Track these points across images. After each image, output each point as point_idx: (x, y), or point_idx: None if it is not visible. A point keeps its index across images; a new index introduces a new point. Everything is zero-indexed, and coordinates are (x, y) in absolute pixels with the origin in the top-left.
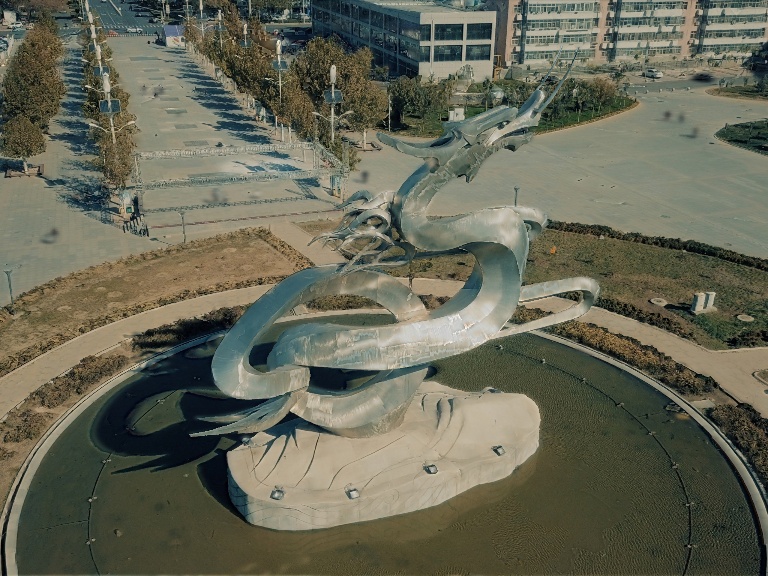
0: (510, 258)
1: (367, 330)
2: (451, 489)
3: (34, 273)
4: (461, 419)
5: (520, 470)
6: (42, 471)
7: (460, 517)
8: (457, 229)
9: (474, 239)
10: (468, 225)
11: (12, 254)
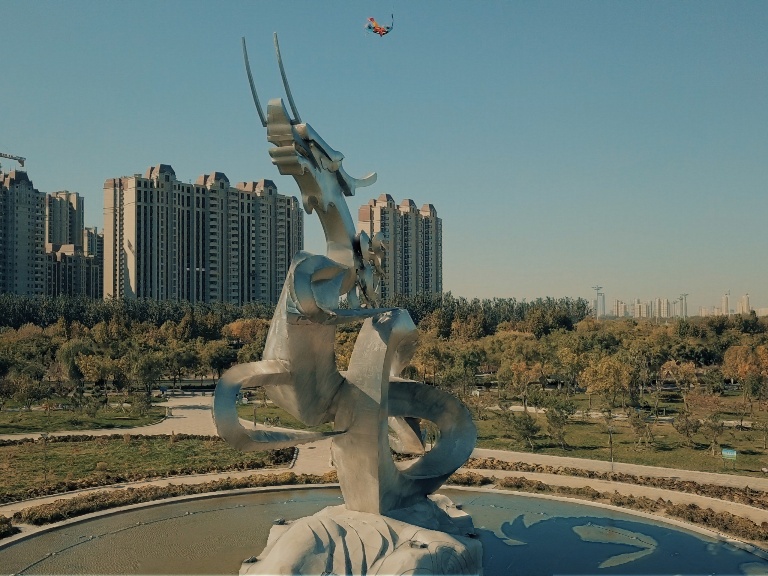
0: None
1: None
2: None
3: None
4: None
5: None
6: (555, 502)
7: None
8: None
9: None
10: None
11: None
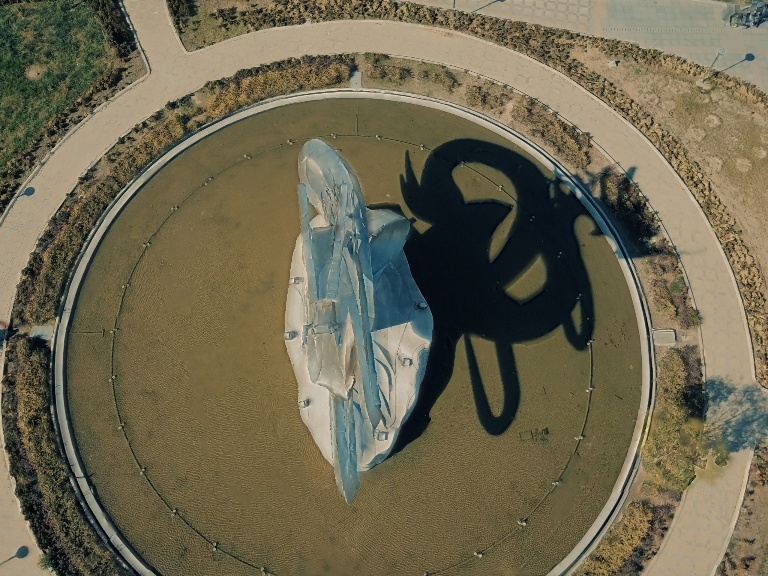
0: None
1: None
2: None
3: None
4: None
5: None
6: (423, 109)
7: None
8: None
9: None
10: None
11: None
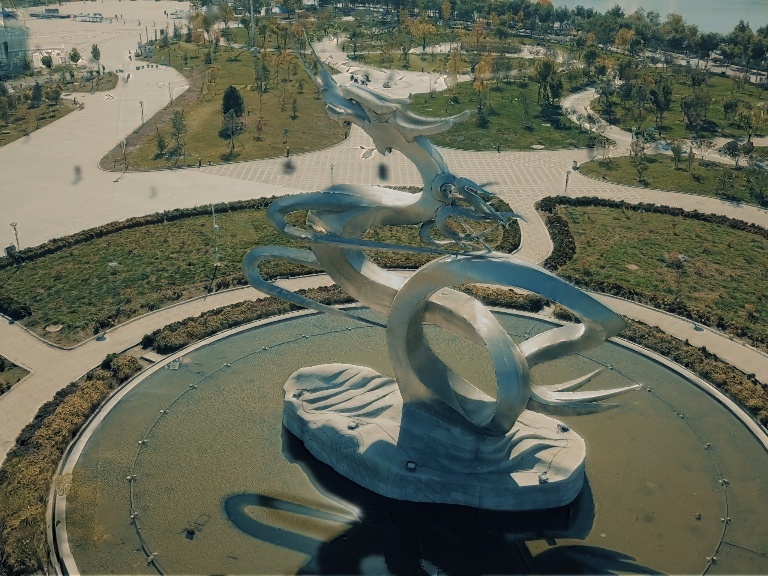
0: None
1: None
2: None
3: None
4: None
5: None
6: None
7: None
8: None
9: None
10: None
11: None
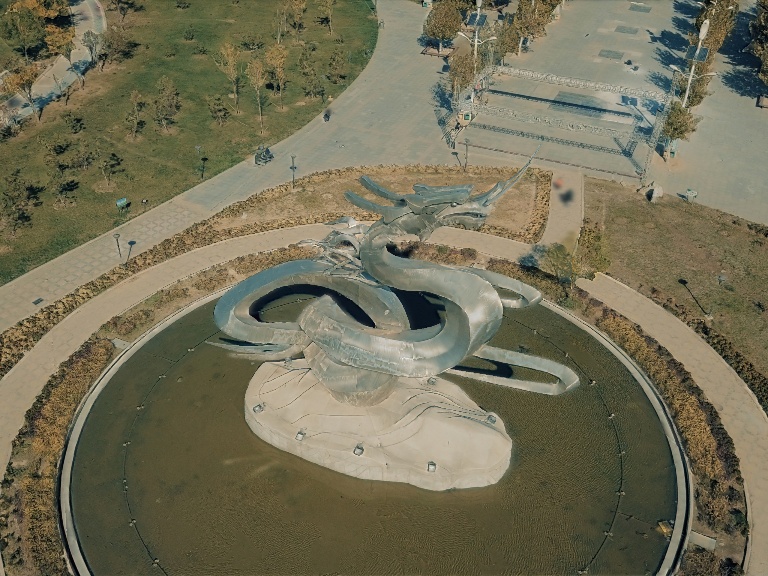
0: (465, 317)
1: (339, 324)
2: (377, 473)
3: (343, 156)
4: (420, 426)
5: (458, 492)
6: (189, 316)
7: (390, 498)
8: (413, 276)
9: (429, 290)
10: (425, 276)
11: (349, 133)
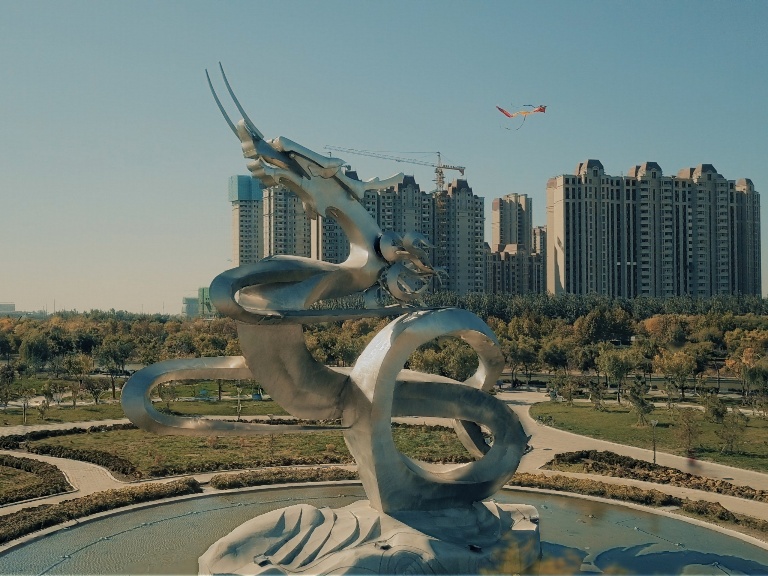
0: None
1: (401, 370)
2: None
3: None
4: None
5: None
6: (719, 535)
7: None
8: None
9: None
10: None
11: None
